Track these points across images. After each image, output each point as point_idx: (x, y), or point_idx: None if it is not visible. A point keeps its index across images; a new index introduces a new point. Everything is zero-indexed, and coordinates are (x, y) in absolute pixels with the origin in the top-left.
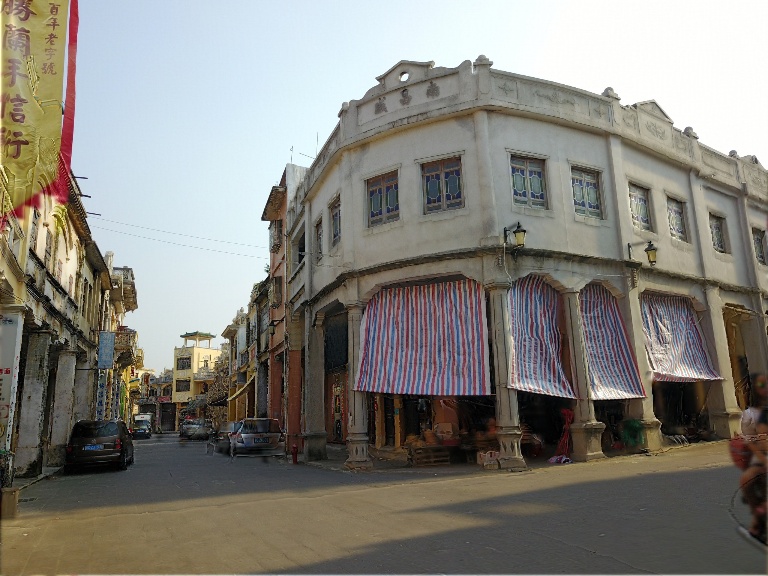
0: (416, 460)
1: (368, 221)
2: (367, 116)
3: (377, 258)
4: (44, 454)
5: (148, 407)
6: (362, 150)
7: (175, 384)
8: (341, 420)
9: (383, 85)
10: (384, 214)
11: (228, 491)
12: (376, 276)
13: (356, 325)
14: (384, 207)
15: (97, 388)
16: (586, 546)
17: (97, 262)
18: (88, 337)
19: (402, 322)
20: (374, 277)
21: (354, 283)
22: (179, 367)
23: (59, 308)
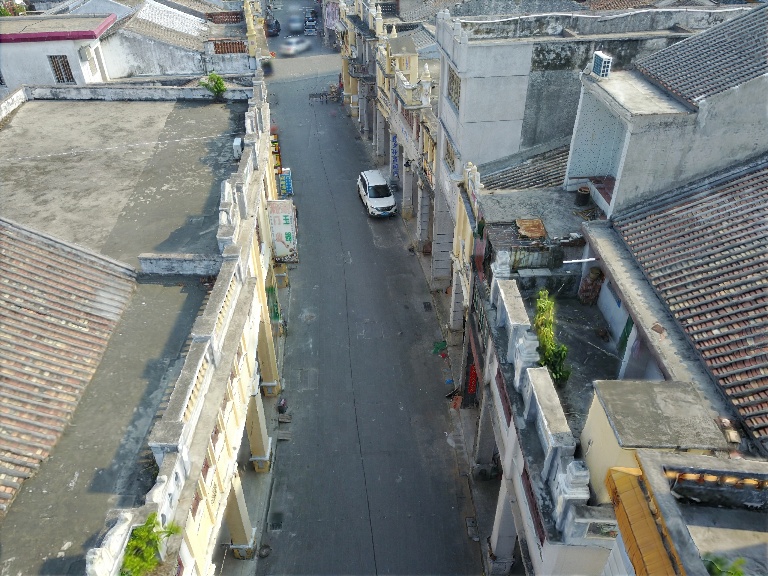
0: (338, 45)
1: None
2: None
3: None
4: None
5: None
6: None
7: None
8: None
9: None
10: None
11: (295, 53)
12: None
13: (325, 10)
14: None
15: None
16: (319, 71)
17: None
18: None
19: (334, 11)
20: None
21: None
22: None
23: None
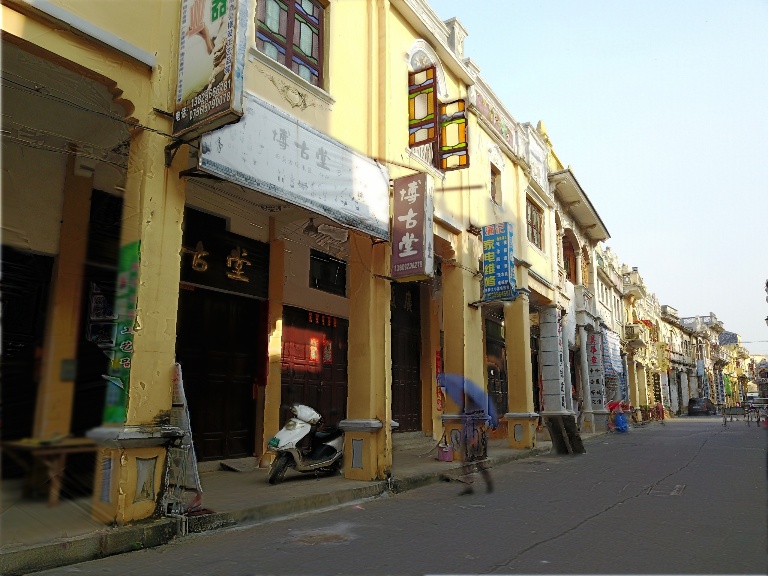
0: None
1: None
2: None
3: None
4: (682, 409)
5: (765, 386)
6: None
7: None
8: None
9: None
10: None
11: None
12: None
13: None
14: None
15: (702, 383)
16: None
17: (689, 332)
18: (692, 363)
19: None
20: None
21: None
22: None
23: (677, 359)
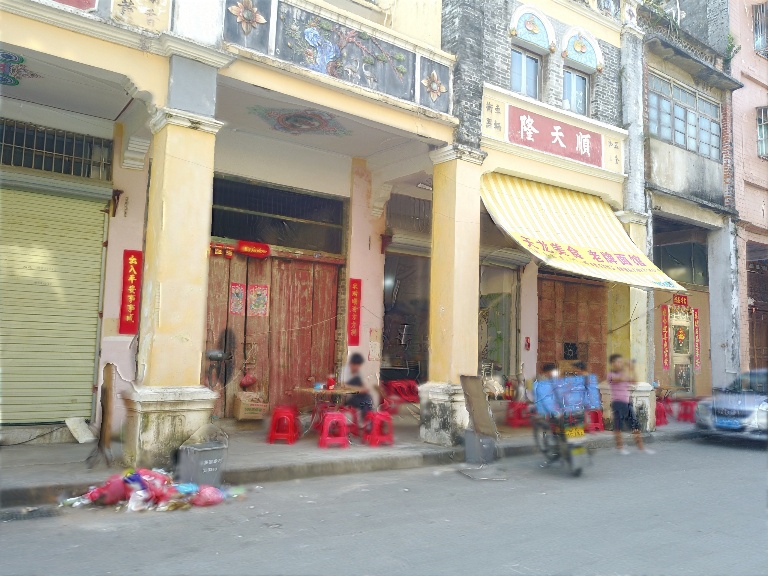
0: None
1: None
2: None
3: None
4: None
5: None
6: None
7: None
8: (692, 365)
9: None
10: None
11: None
12: None
13: None
14: None
15: None
16: None
17: None
18: None
19: None
20: None
21: None
22: None
23: None
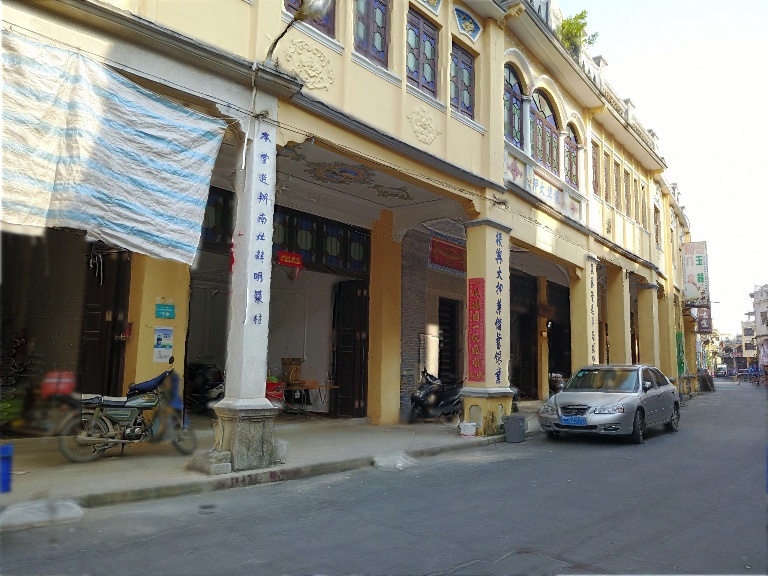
0: None
1: (762, 323)
2: (759, 296)
3: (763, 333)
4: None
5: (728, 359)
6: (759, 304)
7: (744, 345)
8: None
9: (762, 289)
10: (765, 322)
11: None
12: (763, 337)
13: (760, 348)
14: (765, 320)
15: None
16: None
17: None
18: None
19: None
20: (763, 337)
21: (759, 338)
22: (746, 334)
23: None
